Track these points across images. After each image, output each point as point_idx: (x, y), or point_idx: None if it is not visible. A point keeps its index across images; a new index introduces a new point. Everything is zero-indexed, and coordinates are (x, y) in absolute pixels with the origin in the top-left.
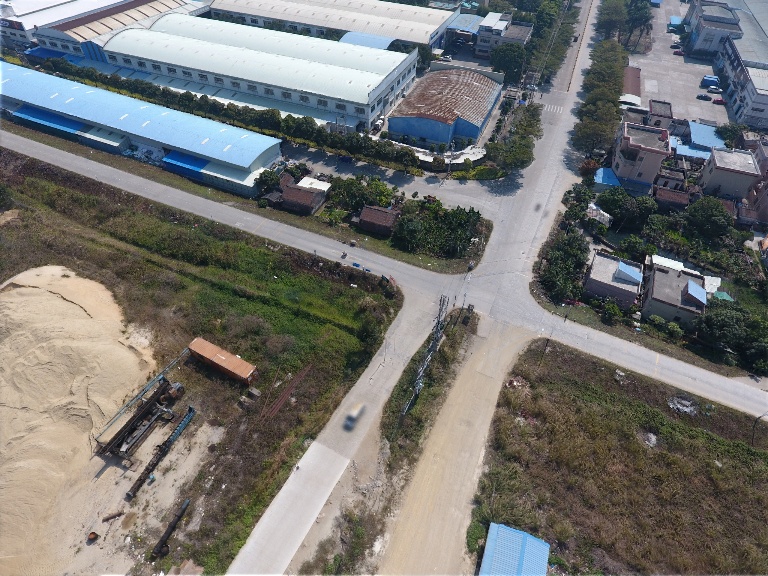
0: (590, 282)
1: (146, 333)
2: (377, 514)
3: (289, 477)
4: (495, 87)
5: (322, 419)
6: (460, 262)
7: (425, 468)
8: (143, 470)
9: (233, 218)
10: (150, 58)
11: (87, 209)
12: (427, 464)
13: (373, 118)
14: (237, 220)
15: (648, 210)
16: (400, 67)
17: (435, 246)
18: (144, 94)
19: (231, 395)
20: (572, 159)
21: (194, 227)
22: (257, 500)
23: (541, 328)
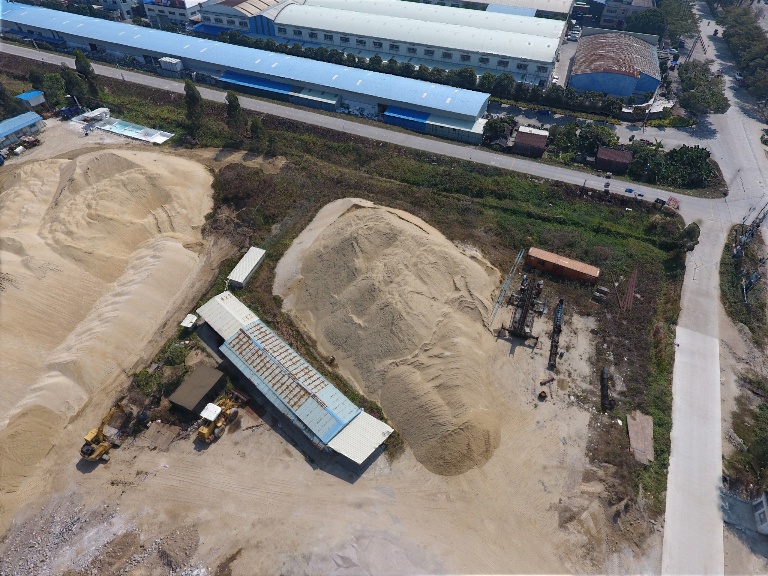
0: None
1: (472, 248)
2: None
3: (675, 352)
4: (652, 48)
5: (678, 308)
6: (710, 190)
7: None
8: (549, 348)
9: (485, 158)
10: (324, 28)
11: (344, 154)
12: None
13: (550, 77)
14: (490, 160)
15: None
16: (563, 31)
17: (677, 178)
18: (332, 60)
19: (583, 293)
20: (747, 109)
21: (453, 166)
22: (661, 368)
23: None
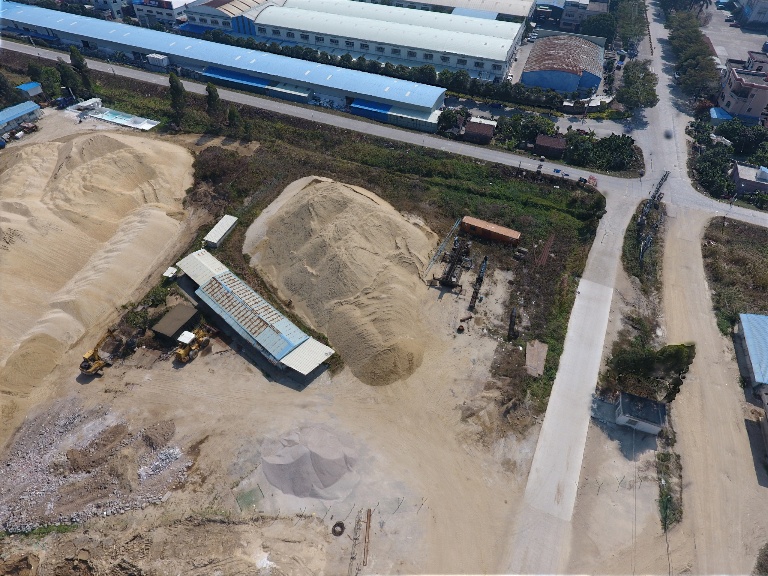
0: (740, 181)
1: (417, 217)
2: (649, 316)
3: (576, 297)
4: (599, 49)
5: (583, 264)
6: (630, 172)
7: (669, 292)
8: (471, 294)
9: (436, 144)
10: (300, 29)
11: (312, 140)
12: (670, 290)
13: (505, 74)
14: (440, 145)
15: (762, 136)
16: (519, 33)
17: (603, 162)
18: (306, 57)
19: (506, 252)
20: (679, 104)
21: (408, 151)
22: (562, 309)
23: (715, 210)
